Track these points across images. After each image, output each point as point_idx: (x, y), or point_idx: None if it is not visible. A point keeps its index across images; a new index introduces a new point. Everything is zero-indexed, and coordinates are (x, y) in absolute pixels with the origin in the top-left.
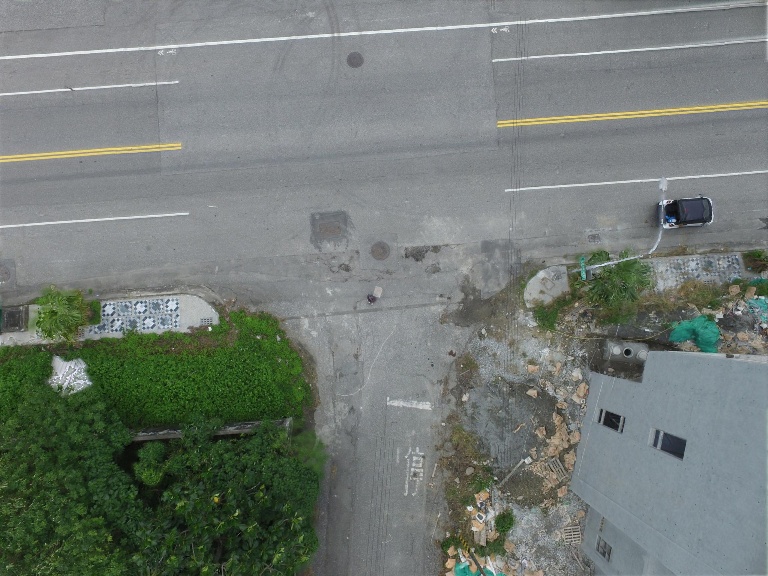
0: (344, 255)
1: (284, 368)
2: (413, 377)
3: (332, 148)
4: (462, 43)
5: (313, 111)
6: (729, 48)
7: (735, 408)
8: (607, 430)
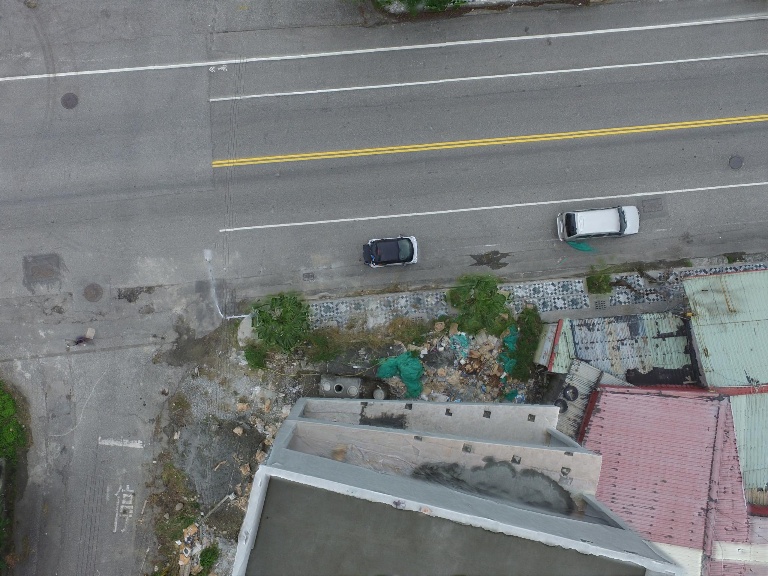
0: (57, 297)
1: None
2: (125, 416)
3: (45, 191)
4: (180, 82)
5: (26, 153)
6: (444, 86)
7: None
8: None
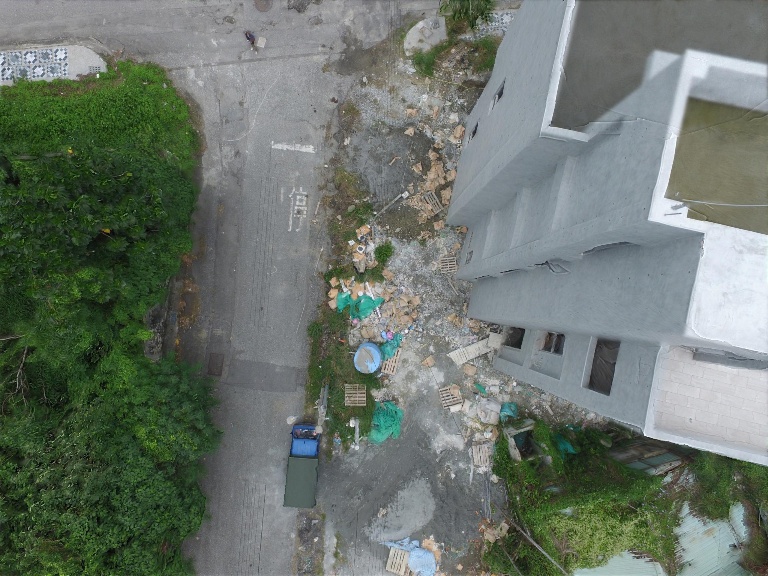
0: (228, 7)
1: (170, 111)
2: (297, 122)
3: None
4: None
5: None
6: None
7: (532, 8)
8: (469, 143)
